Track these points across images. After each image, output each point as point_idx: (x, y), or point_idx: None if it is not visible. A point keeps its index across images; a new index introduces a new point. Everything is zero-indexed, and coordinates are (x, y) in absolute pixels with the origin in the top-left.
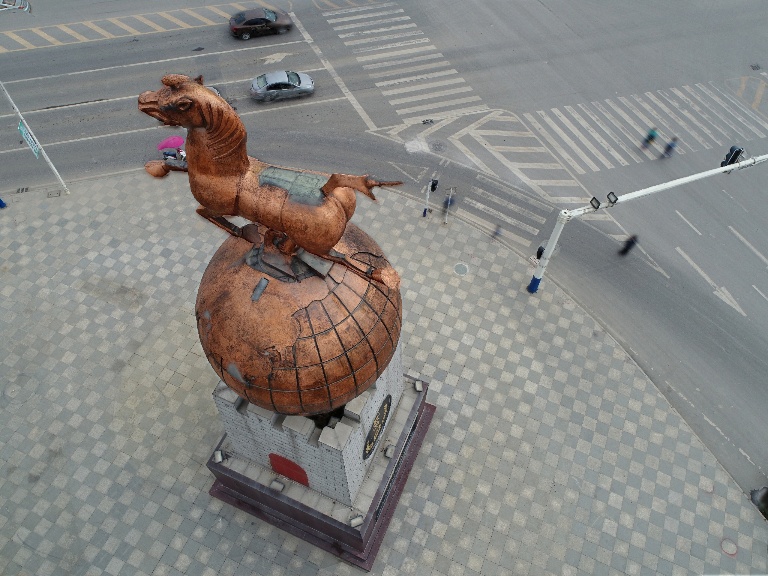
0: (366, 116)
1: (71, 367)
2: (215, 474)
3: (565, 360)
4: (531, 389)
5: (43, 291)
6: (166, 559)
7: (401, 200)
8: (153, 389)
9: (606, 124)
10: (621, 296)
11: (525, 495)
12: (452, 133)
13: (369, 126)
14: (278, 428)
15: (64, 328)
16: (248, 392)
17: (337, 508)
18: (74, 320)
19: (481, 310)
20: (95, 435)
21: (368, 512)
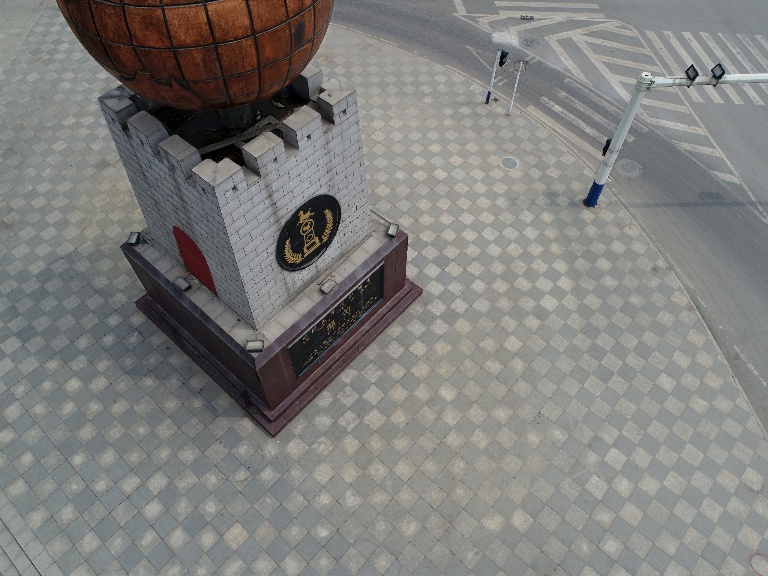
0: (459, 0)
1: (58, 154)
2: (134, 268)
3: (605, 286)
4: (549, 305)
5: (64, 84)
6: (64, 354)
7: (466, 83)
8: (126, 194)
9: (748, 59)
10: (705, 238)
11: (497, 415)
12: (551, 33)
13: (458, 10)
14: (160, 158)
15: (68, 119)
16: (71, 10)
17: (240, 326)
18: (80, 115)
19: (518, 208)
20: (51, 220)
21: (274, 342)
